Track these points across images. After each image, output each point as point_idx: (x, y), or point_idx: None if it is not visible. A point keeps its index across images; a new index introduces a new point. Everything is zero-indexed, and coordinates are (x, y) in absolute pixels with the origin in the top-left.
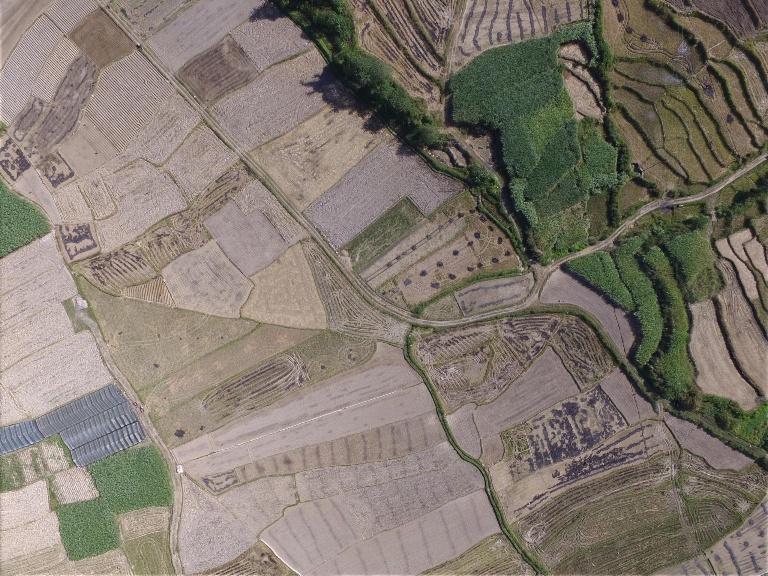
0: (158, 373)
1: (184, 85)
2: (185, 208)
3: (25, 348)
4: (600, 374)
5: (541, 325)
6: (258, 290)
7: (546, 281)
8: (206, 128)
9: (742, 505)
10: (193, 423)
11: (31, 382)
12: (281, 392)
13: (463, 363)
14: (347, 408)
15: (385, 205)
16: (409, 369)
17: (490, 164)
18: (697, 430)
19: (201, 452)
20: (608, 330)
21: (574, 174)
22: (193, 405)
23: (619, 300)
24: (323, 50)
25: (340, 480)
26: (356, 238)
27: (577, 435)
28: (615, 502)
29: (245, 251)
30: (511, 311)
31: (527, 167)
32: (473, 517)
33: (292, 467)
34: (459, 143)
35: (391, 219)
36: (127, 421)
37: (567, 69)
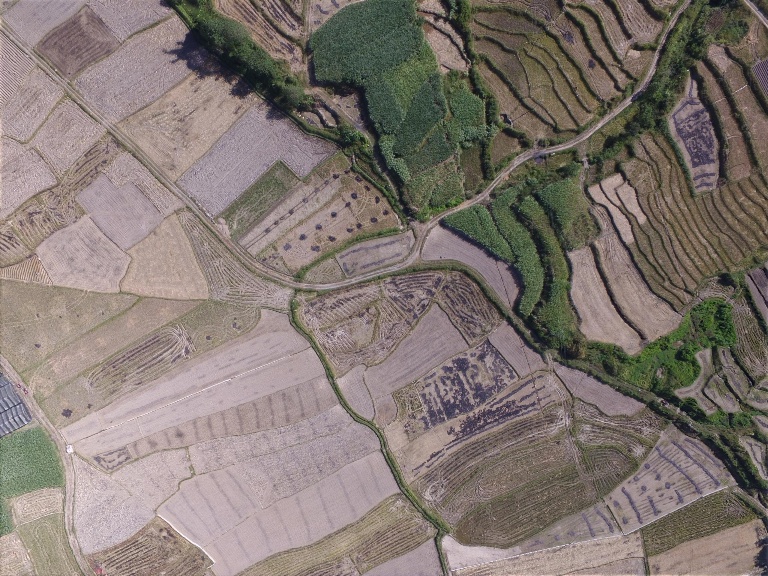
0: (40, 353)
1: (44, 59)
2: (55, 184)
3: None
4: (487, 328)
5: (425, 282)
6: (136, 263)
7: (426, 238)
8: (70, 102)
9: (637, 450)
10: (80, 402)
11: None
12: (167, 365)
13: (350, 325)
14: (236, 377)
15: (259, 170)
16: (296, 334)
17: (359, 123)
18: (587, 378)
19: (90, 431)
20: (491, 283)
21: (443, 128)
22: (79, 384)
23: (498, 252)
24: (183, 16)
25: (234, 450)
26: (232, 205)
27: (469, 390)
28: (512, 455)
29: (120, 225)
30: (394, 270)
31: (393, 123)
32: (371, 479)
33: (185, 440)
34: (326, 103)
35: (266, 184)
36: (11, 403)
37: (428, 23)
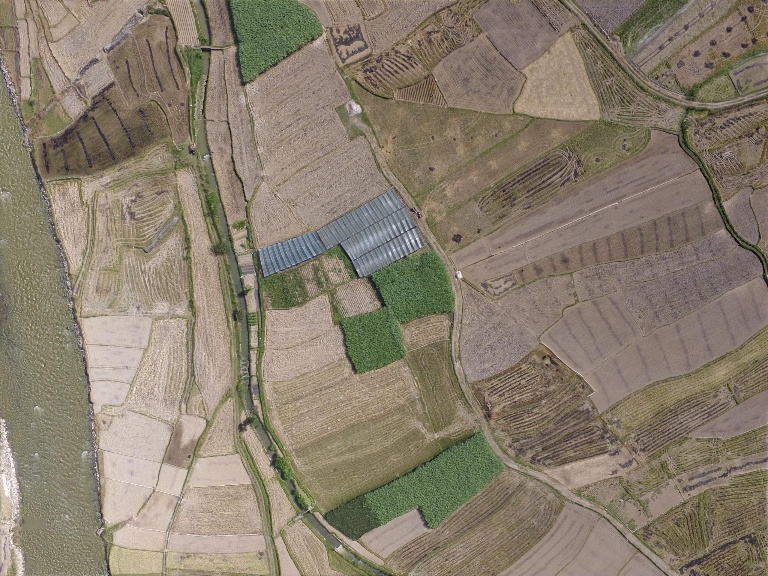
0: (434, 177)
1: None
2: (455, 1)
3: (301, 159)
4: None
5: None
6: (530, 83)
7: None
8: None
9: None
10: (470, 227)
11: (308, 194)
12: (556, 189)
13: (738, 146)
14: (623, 201)
15: None
16: (684, 156)
17: None
18: None
19: (479, 256)
20: None
21: None
22: (469, 208)
23: None
24: None
25: (618, 276)
26: (627, 21)
27: None
28: None
29: (515, 43)
30: None
31: None
32: (752, 306)
33: (569, 266)
34: None
35: None
36: (407, 227)
37: None
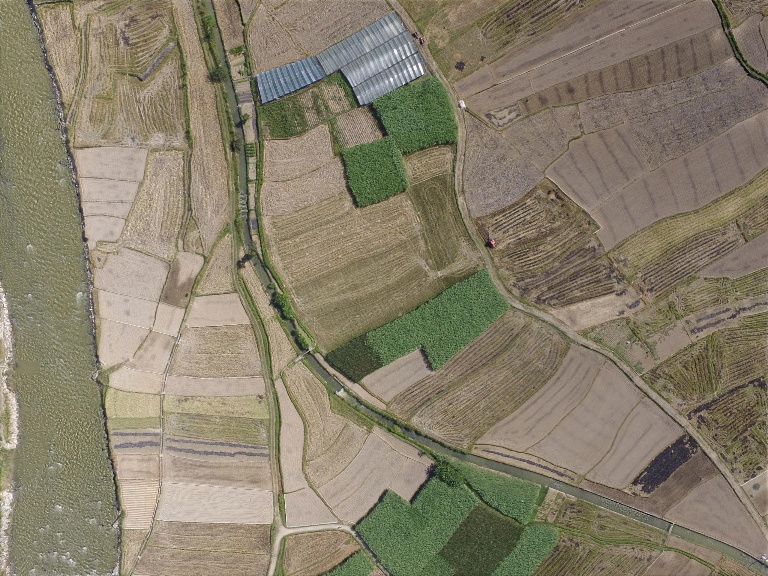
0: (436, 0)
1: None
2: None
3: None
4: None
5: None
6: None
7: None
8: None
9: None
10: (473, 54)
11: (307, 18)
12: (562, 14)
13: None
14: (630, 28)
15: None
16: None
17: None
18: None
19: (482, 85)
20: None
21: None
22: (472, 34)
23: None
24: None
25: (624, 108)
26: None
27: None
28: None
29: None
30: None
31: None
32: (761, 139)
33: (575, 96)
34: None
35: None
36: (408, 52)
37: None
